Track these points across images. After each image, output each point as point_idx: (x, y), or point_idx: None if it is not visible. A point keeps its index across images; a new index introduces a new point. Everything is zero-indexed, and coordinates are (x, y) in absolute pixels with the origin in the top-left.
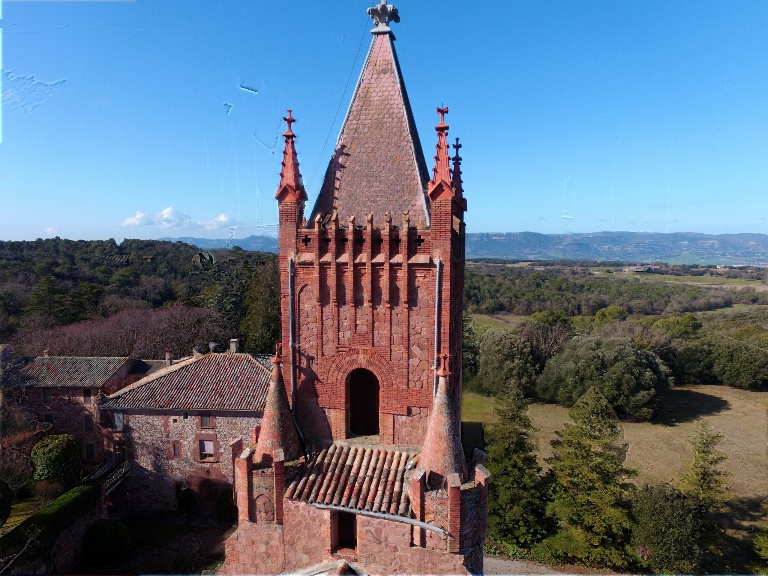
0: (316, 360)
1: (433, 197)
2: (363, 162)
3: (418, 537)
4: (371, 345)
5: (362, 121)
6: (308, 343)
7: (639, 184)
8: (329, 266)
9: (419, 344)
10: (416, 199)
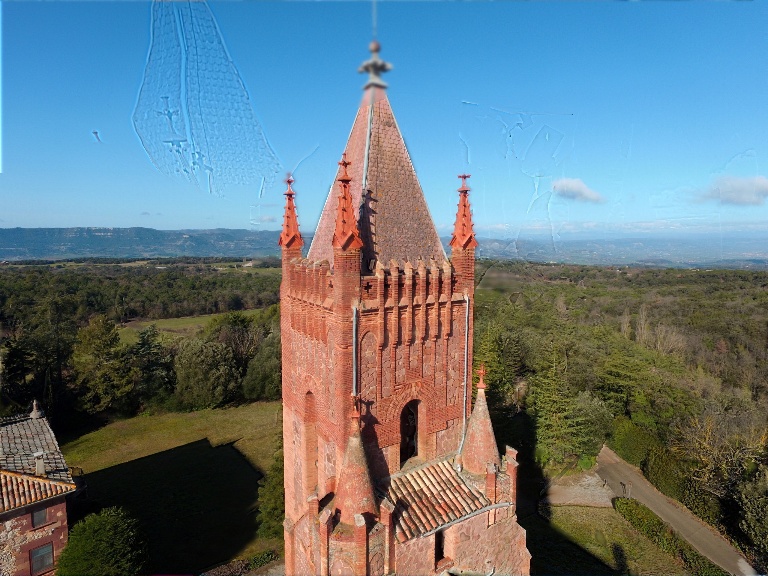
0: (375, 404)
1: (464, 246)
2: (390, 209)
3: (493, 518)
4: (421, 377)
5: (381, 169)
6: (368, 389)
7: (308, 196)
8: (391, 311)
9: (453, 367)
10: (437, 245)
